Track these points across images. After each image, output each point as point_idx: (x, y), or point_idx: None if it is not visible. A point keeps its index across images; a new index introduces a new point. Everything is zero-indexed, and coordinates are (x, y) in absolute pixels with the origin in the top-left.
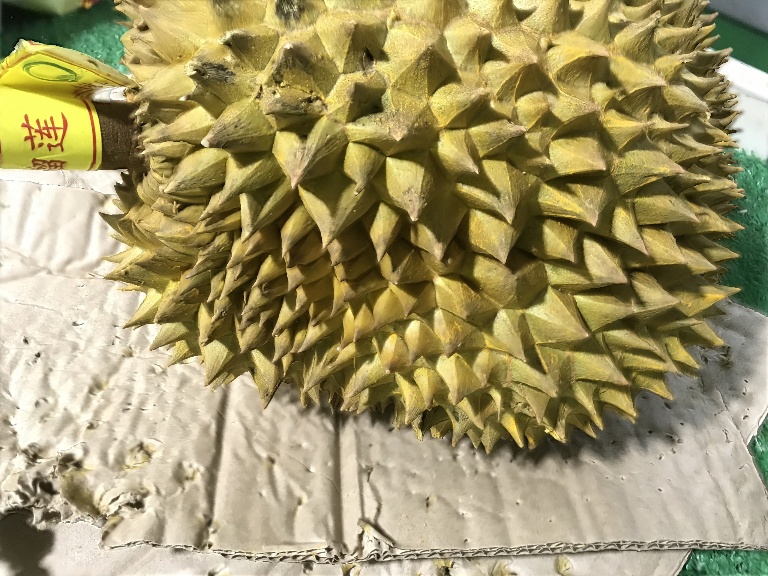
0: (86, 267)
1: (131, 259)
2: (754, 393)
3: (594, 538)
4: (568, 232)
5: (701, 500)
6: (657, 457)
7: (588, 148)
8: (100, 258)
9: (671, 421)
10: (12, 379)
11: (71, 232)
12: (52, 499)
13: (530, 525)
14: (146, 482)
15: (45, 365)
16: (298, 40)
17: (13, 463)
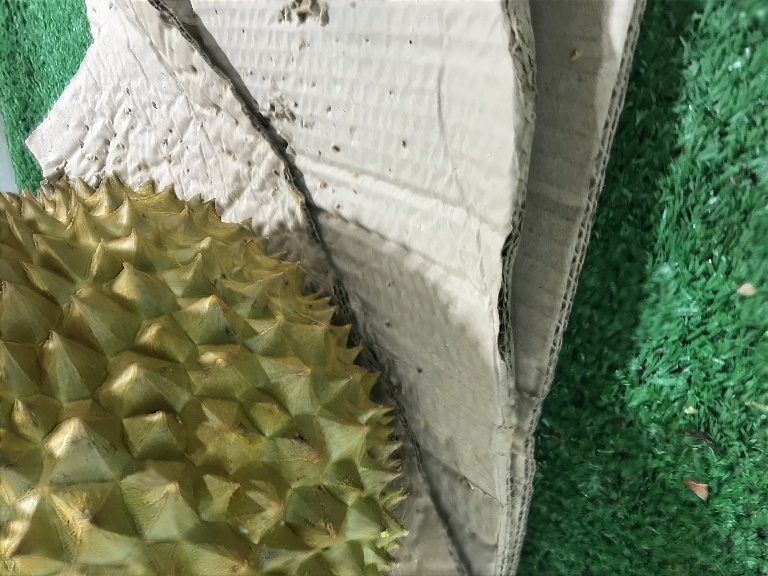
0: None
1: None
2: None
3: None
4: None
5: None
6: None
7: None
8: None
9: None
10: (118, 113)
11: (152, 31)
12: None
13: None
14: None
15: (131, 121)
16: None
17: None
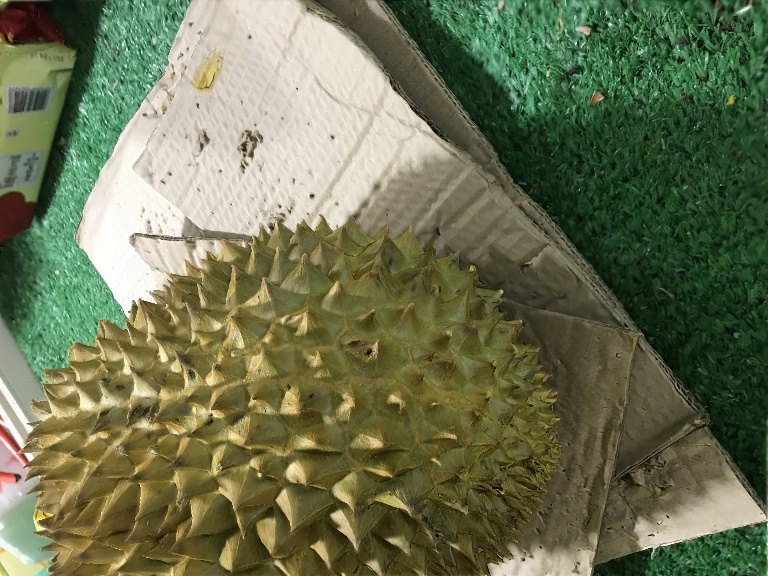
0: None
1: None
2: (670, 527)
3: None
4: None
5: None
6: (508, 558)
7: None
8: None
9: (532, 543)
10: None
11: None
12: None
13: None
14: None
15: None
16: None
17: None
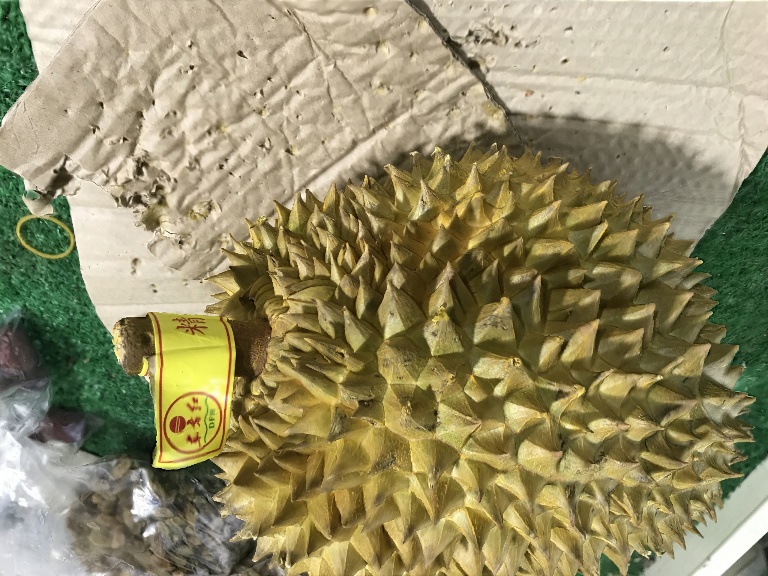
0: (290, 4)
1: (229, 289)
2: None
3: None
4: None
5: None
6: None
7: None
8: (308, 8)
9: None
10: (162, 74)
11: None
12: (137, 206)
13: None
14: (193, 234)
15: (192, 80)
16: (274, 550)
17: (127, 161)
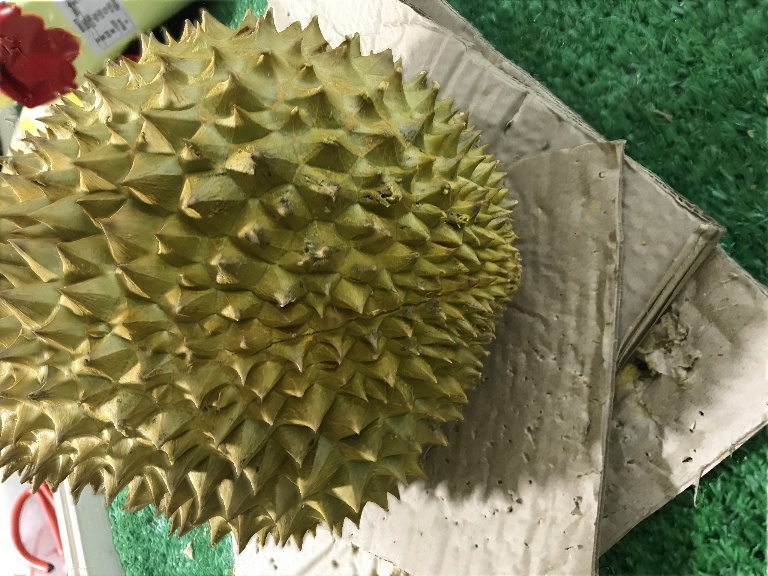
0: None
1: None
2: (708, 432)
3: (409, 569)
4: (134, 483)
5: (503, 570)
6: (492, 512)
7: (76, 467)
8: None
9: (519, 477)
10: None
11: None
12: None
13: (383, 540)
14: None
15: None
16: None
17: None
